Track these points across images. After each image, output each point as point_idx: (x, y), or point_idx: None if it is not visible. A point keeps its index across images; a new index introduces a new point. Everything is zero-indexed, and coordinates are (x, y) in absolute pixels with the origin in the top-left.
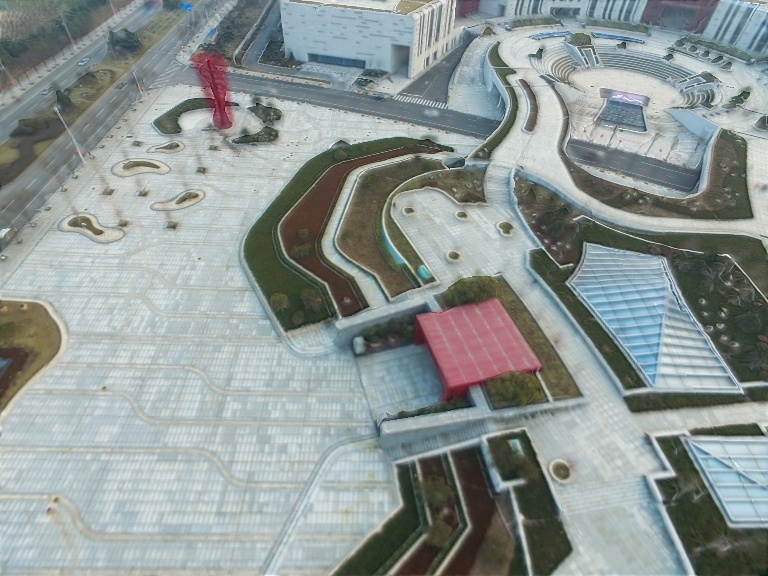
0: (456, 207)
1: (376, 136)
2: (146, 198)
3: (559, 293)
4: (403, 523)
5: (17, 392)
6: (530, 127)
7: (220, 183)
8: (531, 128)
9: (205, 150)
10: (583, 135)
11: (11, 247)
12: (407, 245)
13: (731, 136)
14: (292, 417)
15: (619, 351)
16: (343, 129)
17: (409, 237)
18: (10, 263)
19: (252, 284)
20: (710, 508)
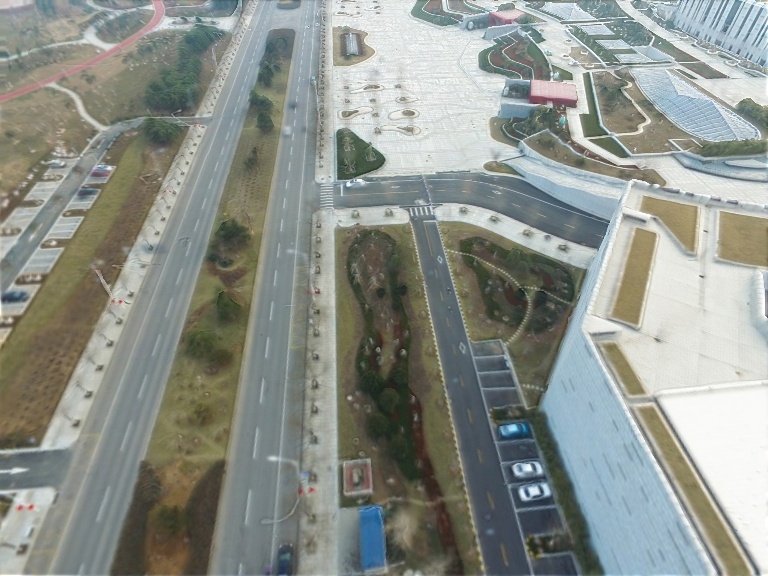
0: None
1: None
2: (360, 8)
3: None
4: None
5: None
6: None
7: None
8: None
9: None
10: None
11: None
12: (478, 6)
13: None
14: None
15: (558, 16)
16: None
17: None
18: (328, 21)
19: (422, 22)
20: None
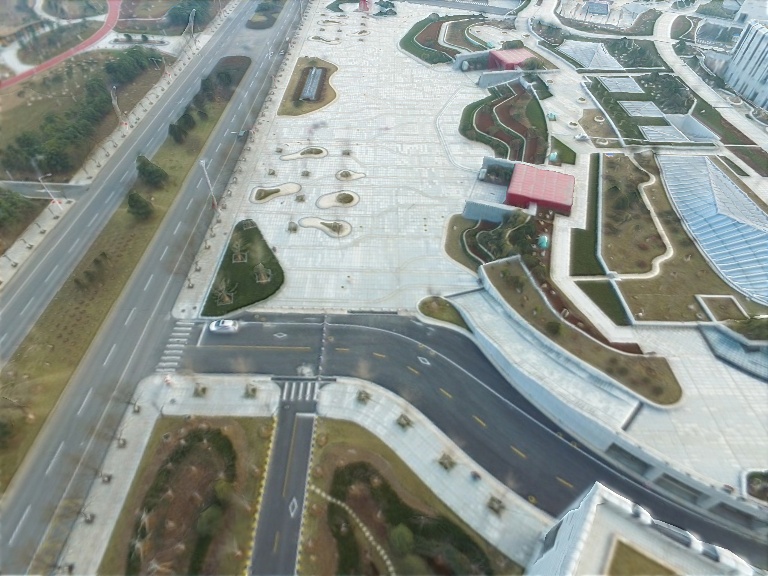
0: (501, 31)
1: (450, 15)
2: (342, 32)
3: (552, 50)
4: (492, 97)
5: (330, 76)
6: (539, 4)
7: (375, 29)
8: (539, 4)
9: (360, 18)
10: (570, 15)
11: (292, 44)
12: (480, 40)
13: (654, 10)
14: None
15: None
16: (431, 12)
17: (480, 38)
18: (296, 48)
19: (409, 56)
20: (603, 88)
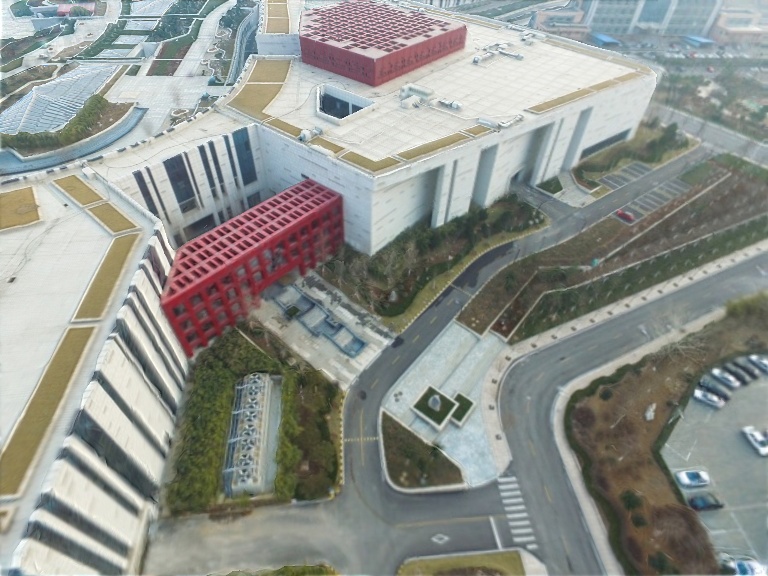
0: None
1: None
2: None
3: None
4: None
5: None
6: None
7: None
8: None
9: None
10: None
11: None
12: None
13: None
14: (8, 29)
15: (129, 11)
16: None
17: None
18: None
19: None
20: None
